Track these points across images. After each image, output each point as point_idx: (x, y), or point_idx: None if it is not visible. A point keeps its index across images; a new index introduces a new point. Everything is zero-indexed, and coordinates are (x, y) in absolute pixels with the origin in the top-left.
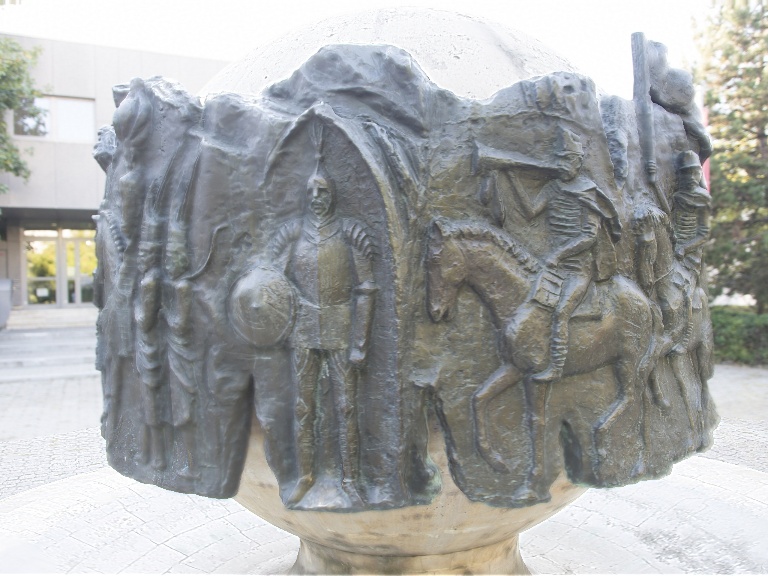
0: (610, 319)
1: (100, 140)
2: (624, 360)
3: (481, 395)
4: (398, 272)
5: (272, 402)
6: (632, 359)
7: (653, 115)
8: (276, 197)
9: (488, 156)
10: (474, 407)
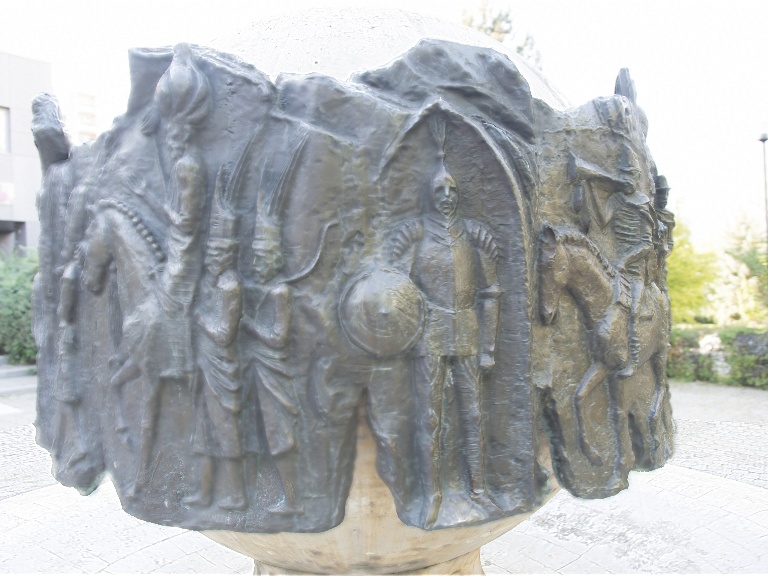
0: (656, 319)
1: (39, 111)
2: (661, 355)
3: (582, 393)
4: (528, 275)
5: (394, 417)
6: (664, 354)
7: (644, 141)
8: (392, 194)
9: (582, 166)
10: (577, 405)
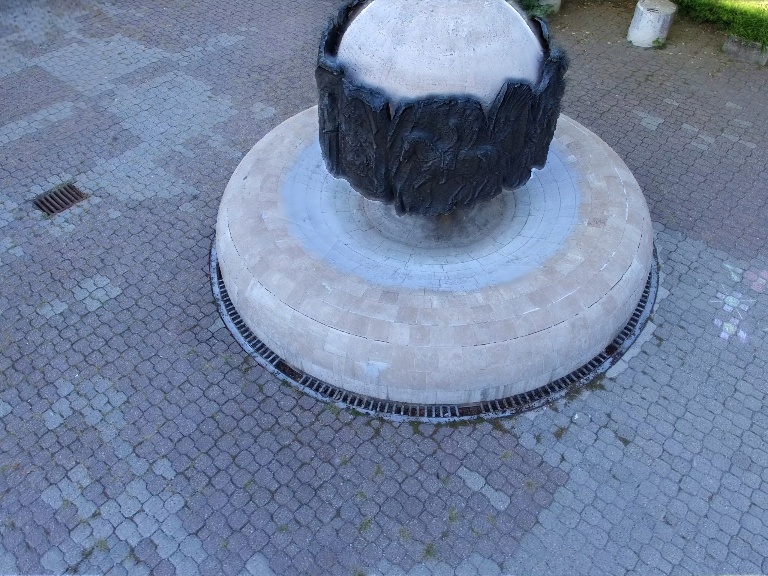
0: None
1: None
2: None
3: None
4: None
5: None
6: None
7: None
8: None
9: None
10: None
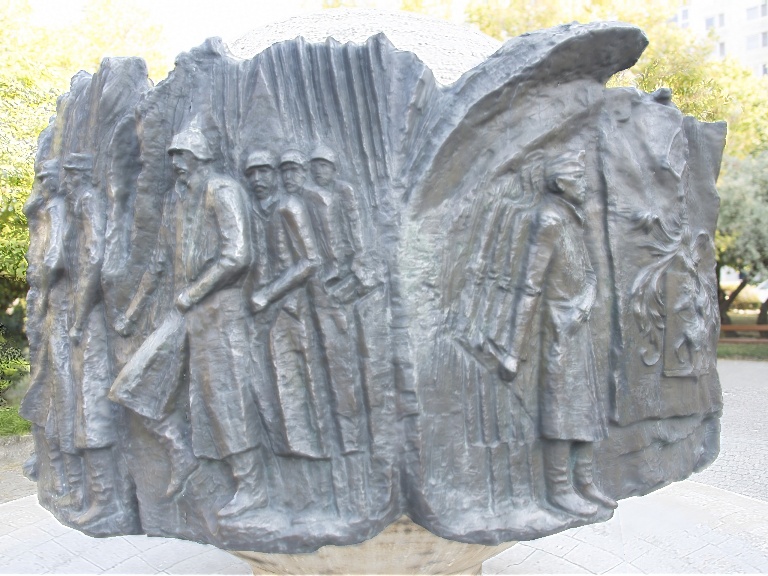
0: None
1: None
2: None
3: None
4: None
5: None
6: None
7: None
8: None
9: None
10: None
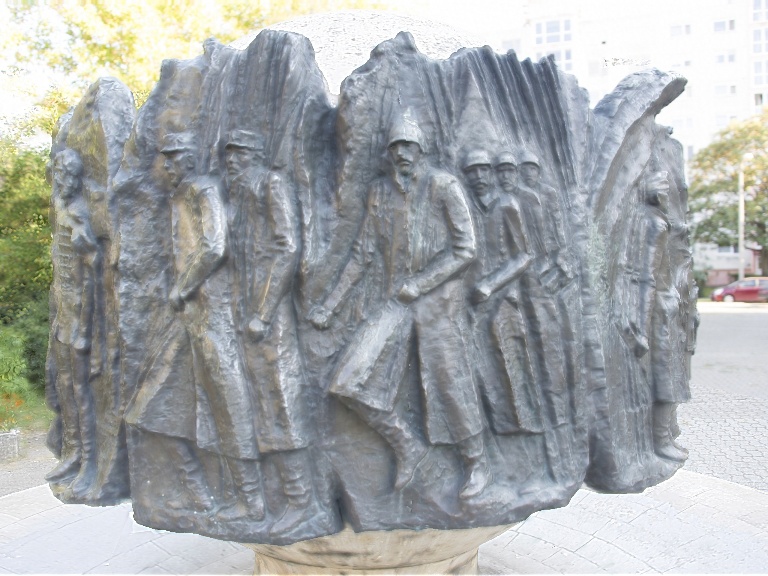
0: None
1: None
2: None
3: None
4: None
5: None
6: None
7: None
8: None
9: None
10: None
